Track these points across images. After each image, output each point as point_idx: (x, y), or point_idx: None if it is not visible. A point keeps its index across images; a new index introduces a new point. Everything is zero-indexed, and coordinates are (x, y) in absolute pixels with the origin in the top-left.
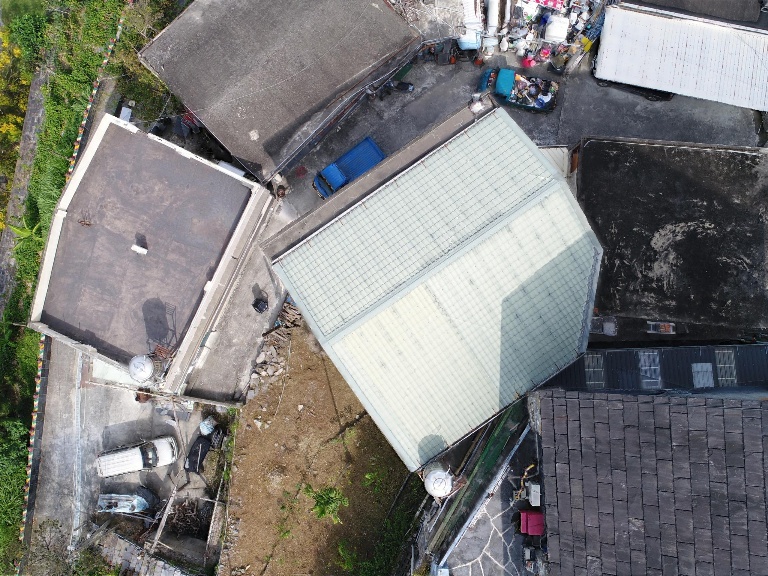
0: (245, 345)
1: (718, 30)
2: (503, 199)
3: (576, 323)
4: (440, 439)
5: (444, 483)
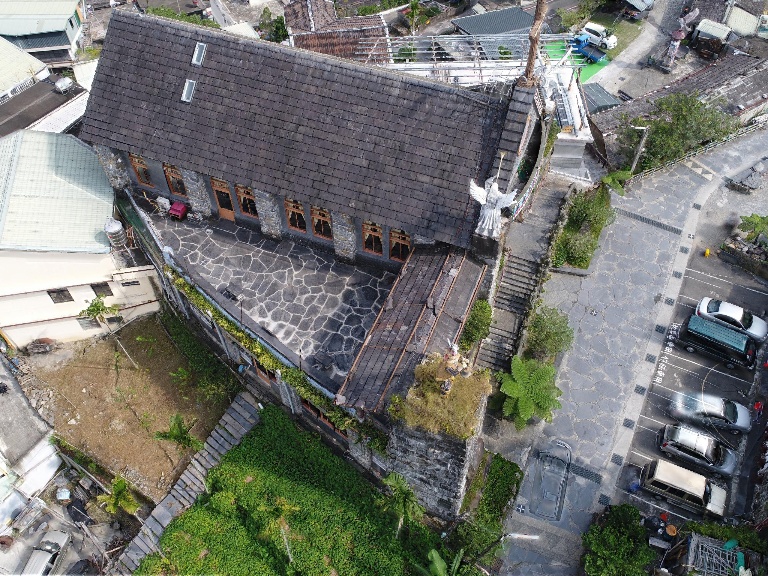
0: (19, 414)
1: (58, 113)
2: (7, 155)
3: None
4: (103, 233)
5: (113, 221)
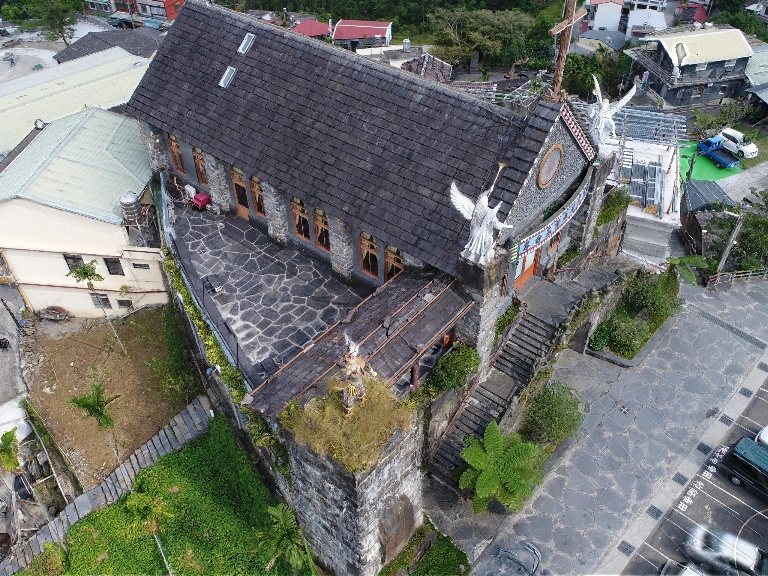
0: (7, 371)
1: None
2: None
3: None
4: None
5: (129, 193)
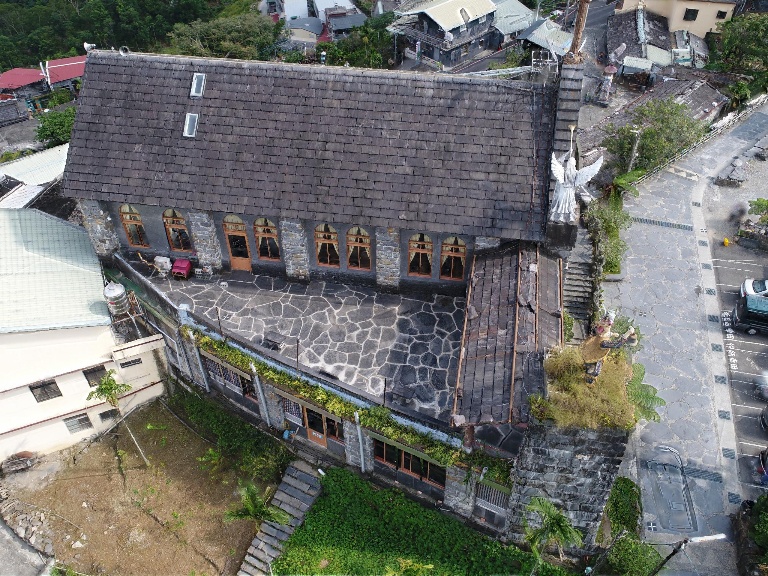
0: (3, 550)
1: None
2: None
3: (72, 230)
4: (98, 303)
5: None
